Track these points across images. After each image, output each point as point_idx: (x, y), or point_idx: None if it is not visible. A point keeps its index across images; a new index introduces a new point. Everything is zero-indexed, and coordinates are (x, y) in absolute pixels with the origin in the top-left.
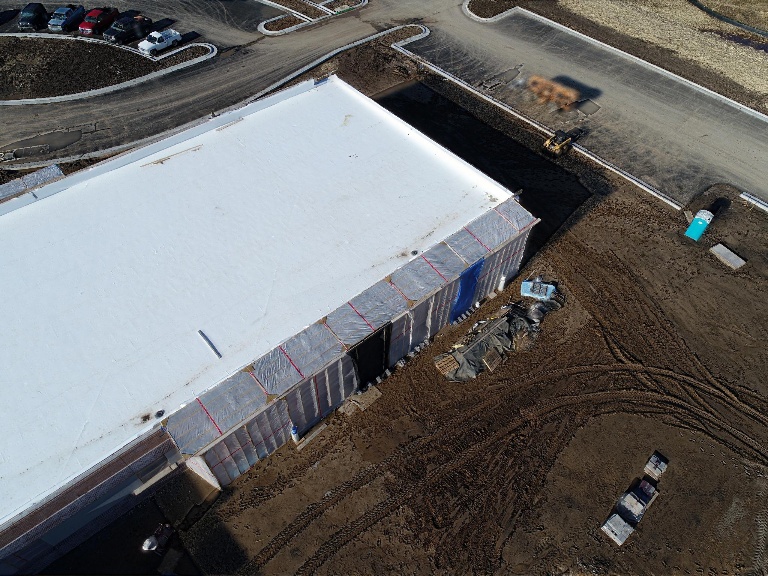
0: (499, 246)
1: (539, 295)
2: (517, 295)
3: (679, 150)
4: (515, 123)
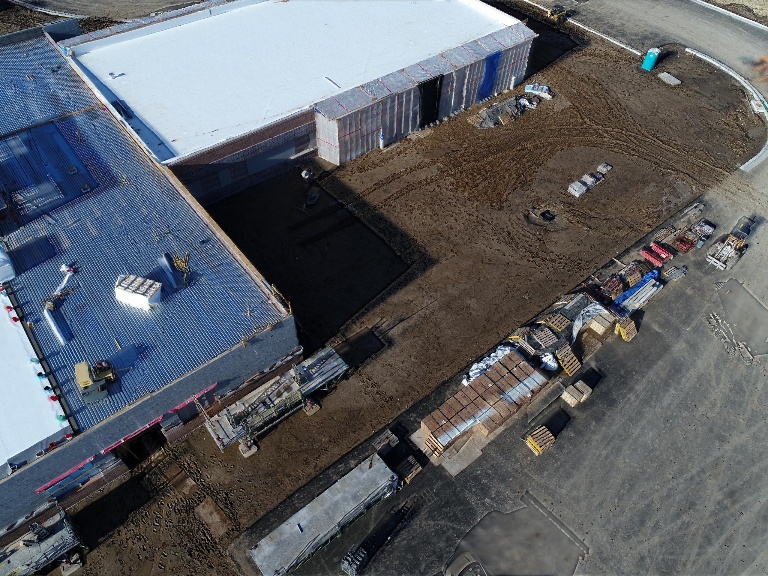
0: (511, 46)
1: (537, 91)
2: (522, 92)
3: (646, 24)
4: (526, 6)
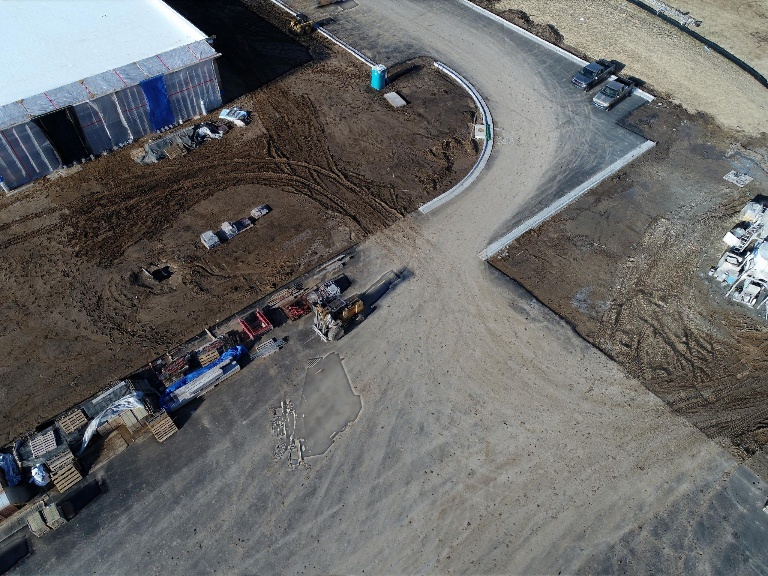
0: (179, 68)
1: (231, 117)
2: (216, 118)
3: (404, 34)
4: (280, 13)
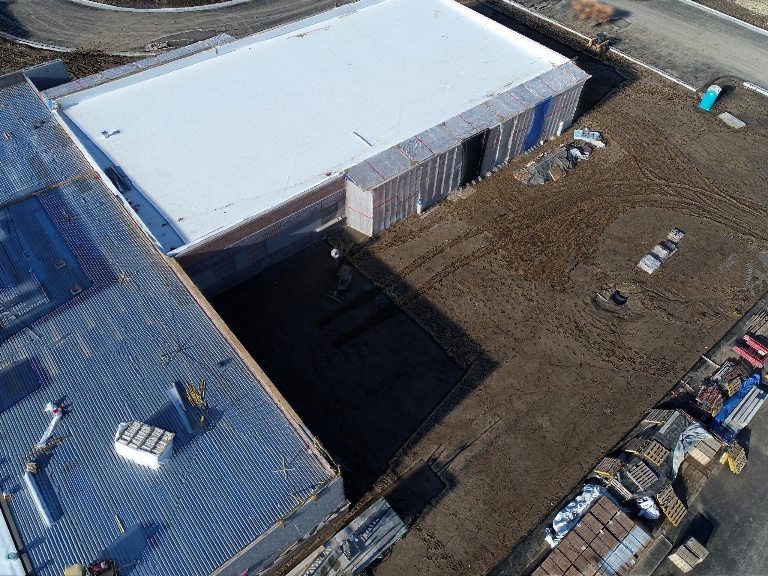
0: (562, 90)
1: (588, 138)
2: (571, 138)
3: (695, 53)
4: (562, 32)
